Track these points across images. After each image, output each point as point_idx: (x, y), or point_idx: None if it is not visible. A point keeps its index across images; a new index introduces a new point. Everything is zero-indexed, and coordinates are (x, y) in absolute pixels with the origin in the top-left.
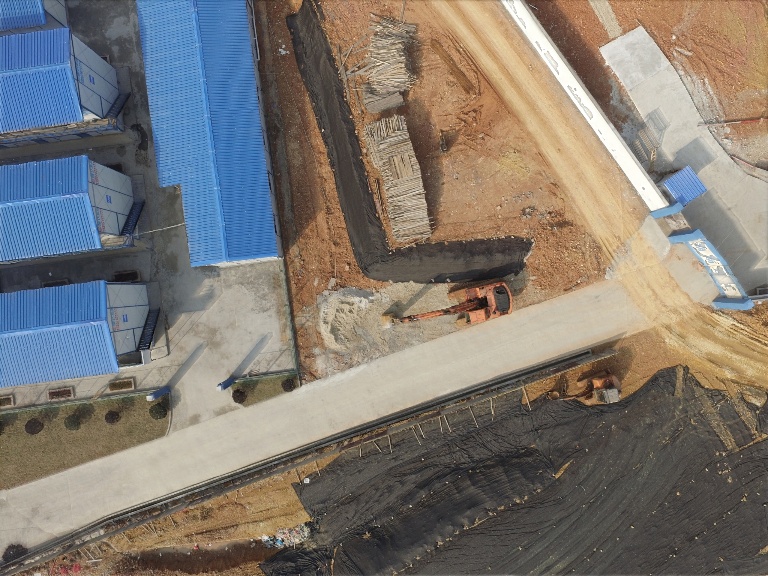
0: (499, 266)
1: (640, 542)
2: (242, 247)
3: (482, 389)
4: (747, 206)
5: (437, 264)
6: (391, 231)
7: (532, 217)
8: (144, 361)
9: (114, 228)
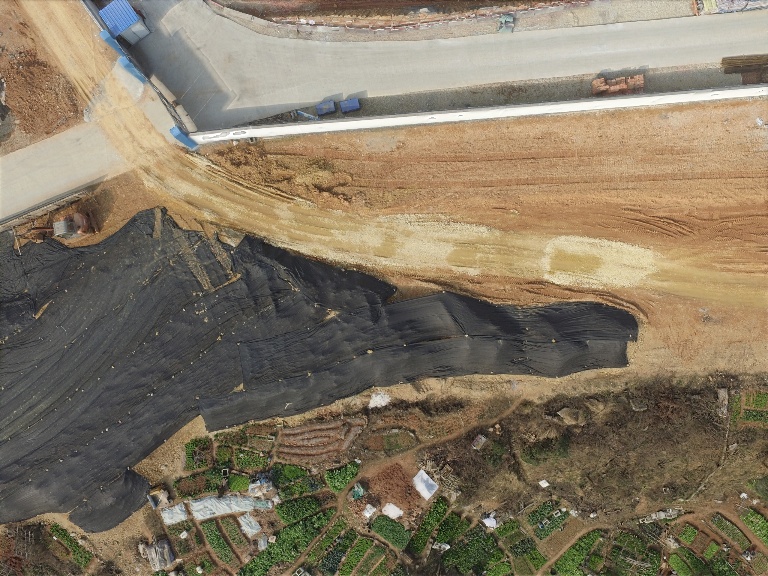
0: None
1: (120, 382)
2: None
3: None
4: (216, 46)
5: None
6: None
7: (2, 57)
8: None
9: None
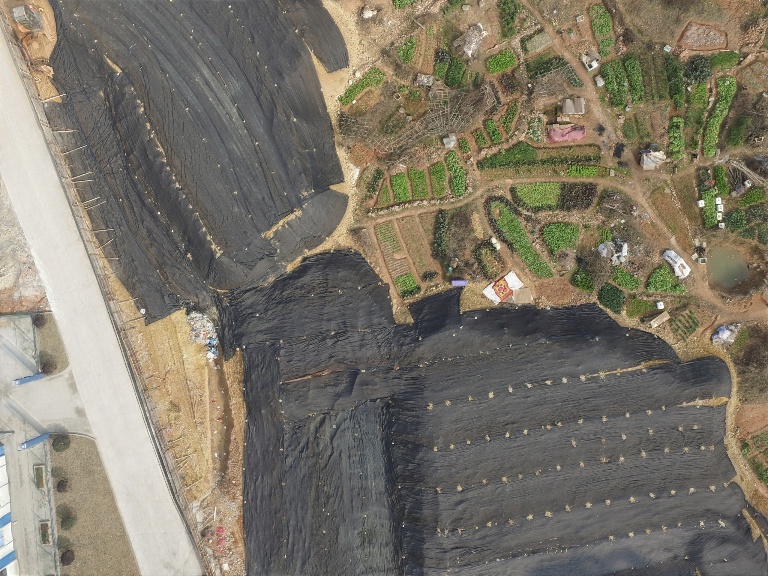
0: None
1: None
2: None
3: None
4: None
5: None
6: None
7: None
8: None
9: None
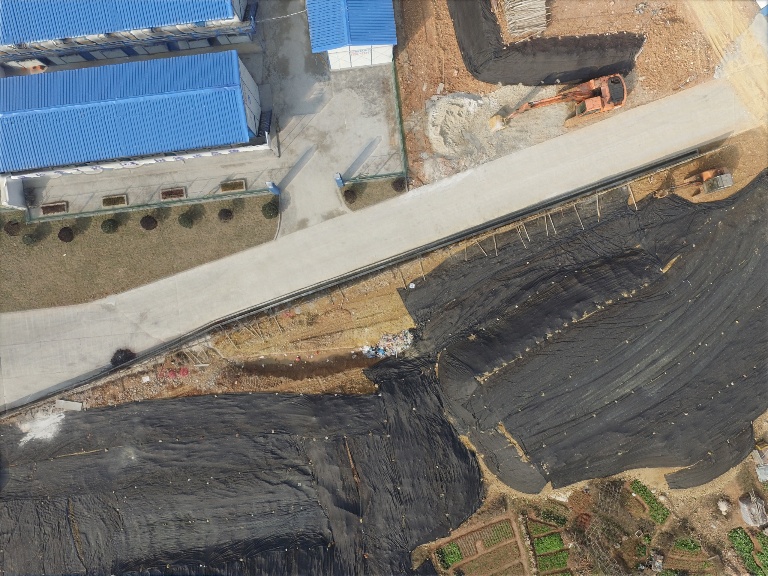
0: (610, 64)
1: (744, 336)
2: (363, 32)
3: (588, 191)
4: None
5: (549, 61)
6: (506, 25)
7: (644, 13)
8: (268, 141)
9: (238, 11)
